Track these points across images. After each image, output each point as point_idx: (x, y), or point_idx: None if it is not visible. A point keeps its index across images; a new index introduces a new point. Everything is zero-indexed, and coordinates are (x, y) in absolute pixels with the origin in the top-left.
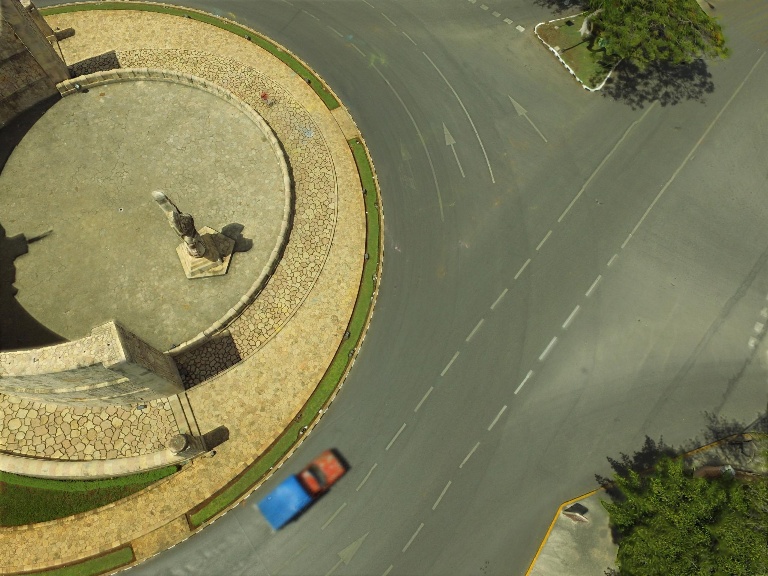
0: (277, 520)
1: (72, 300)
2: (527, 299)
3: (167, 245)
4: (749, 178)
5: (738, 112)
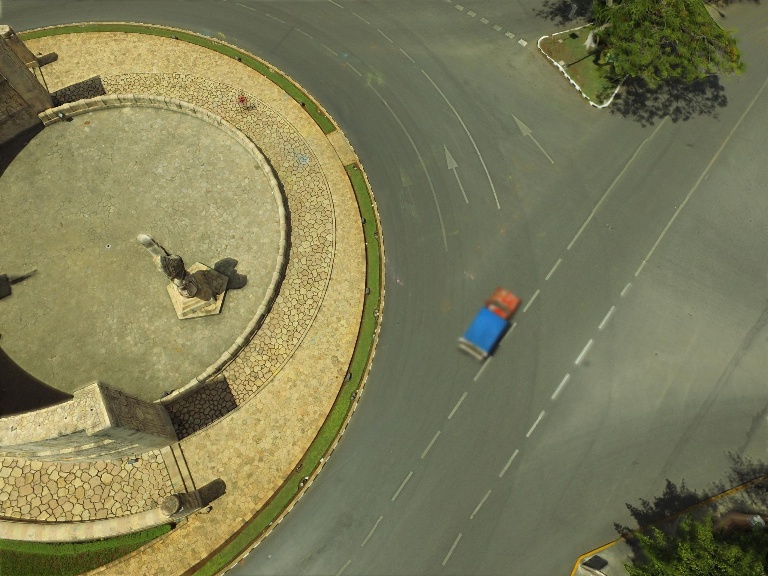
0: None
1: (58, 345)
2: (537, 333)
3: (157, 283)
4: (767, 197)
5: (753, 127)
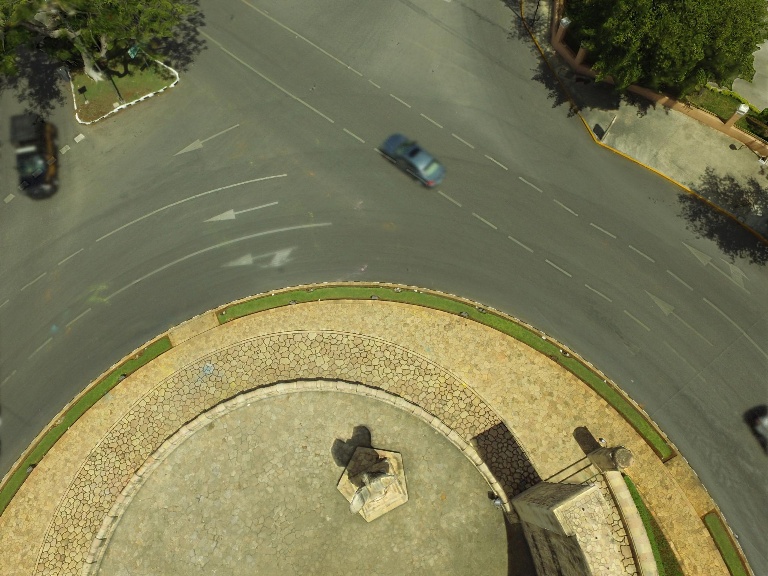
0: (650, 372)
1: None
2: (416, 154)
3: (362, 537)
4: None
5: None
